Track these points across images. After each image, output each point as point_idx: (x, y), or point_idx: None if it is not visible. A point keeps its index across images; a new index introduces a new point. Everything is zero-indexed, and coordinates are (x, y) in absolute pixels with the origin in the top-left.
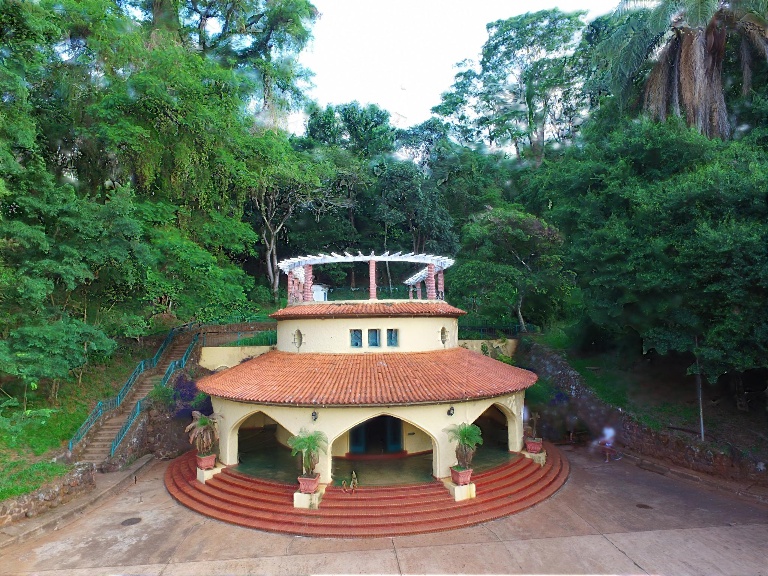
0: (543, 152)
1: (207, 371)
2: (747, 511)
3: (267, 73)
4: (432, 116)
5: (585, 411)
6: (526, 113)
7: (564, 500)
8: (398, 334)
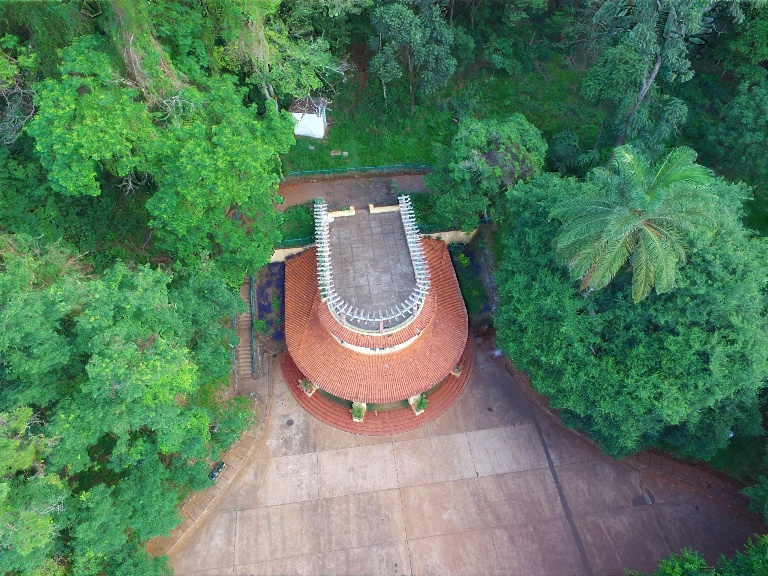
0: None
1: None
2: (528, 414)
3: None
4: None
5: None
6: None
7: (461, 404)
8: None
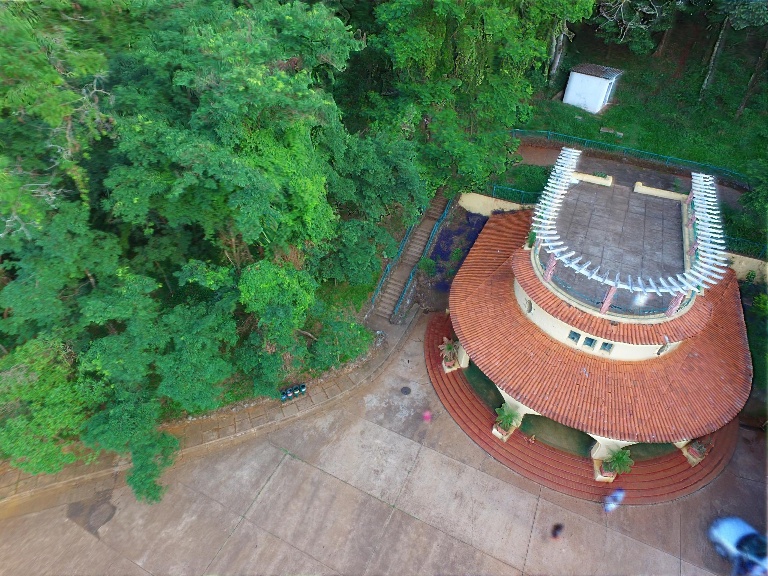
0: None
1: (464, 211)
2: None
3: None
4: None
5: None
6: None
7: (683, 509)
8: (613, 346)
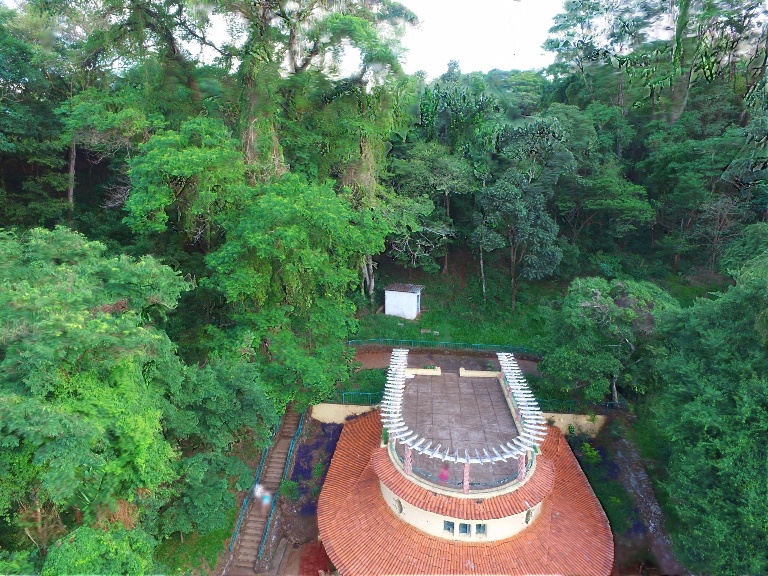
0: (685, 100)
1: (318, 423)
2: None
3: (364, 128)
4: (549, 39)
5: (659, 552)
6: (672, 43)
7: None
8: (486, 526)
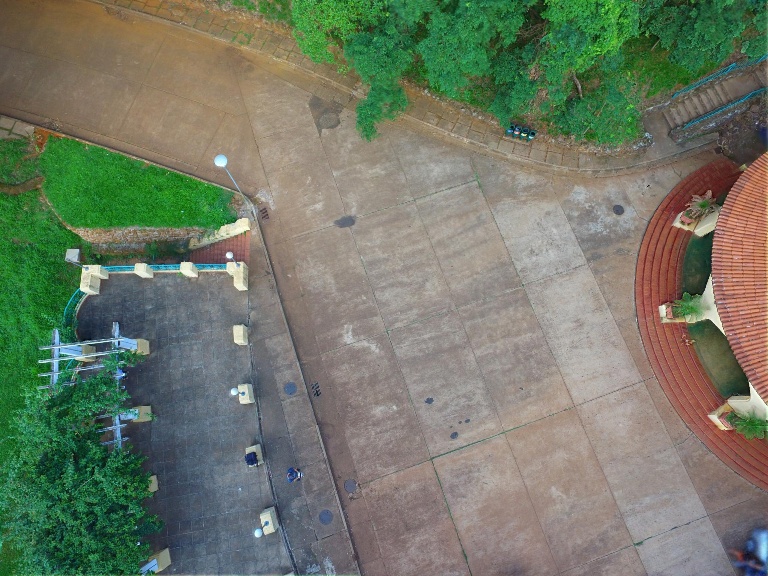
0: None
1: None
2: None
3: None
4: None
5: None
6: None
7: (759, 499)
8: None
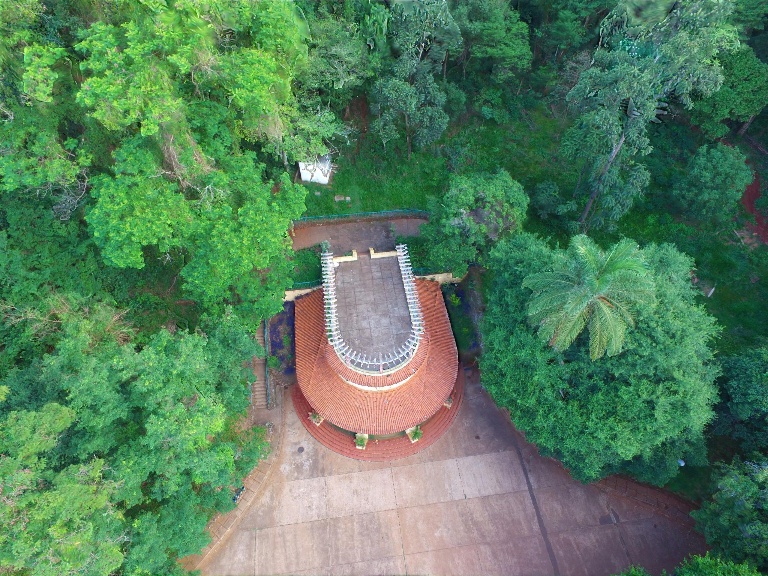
0: None
1: None
2: (511, 441)
3: None
4: None
5: None
6: None
7: (451, 432)
8: None
